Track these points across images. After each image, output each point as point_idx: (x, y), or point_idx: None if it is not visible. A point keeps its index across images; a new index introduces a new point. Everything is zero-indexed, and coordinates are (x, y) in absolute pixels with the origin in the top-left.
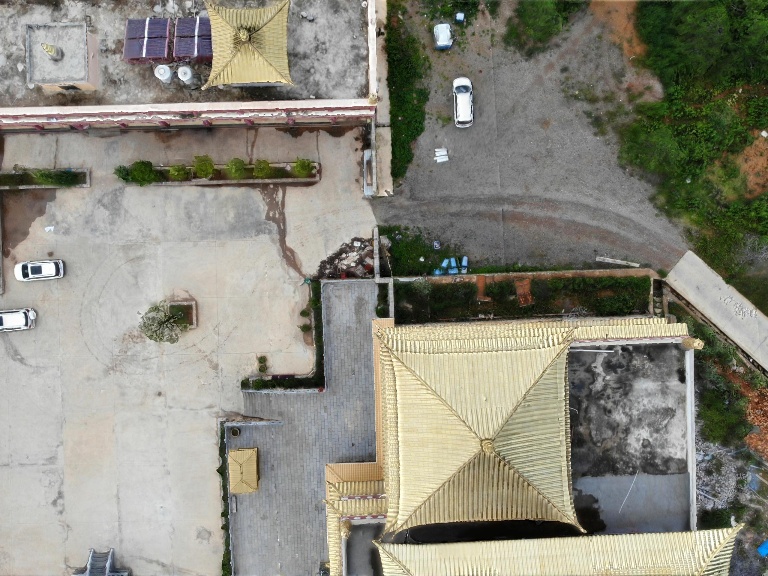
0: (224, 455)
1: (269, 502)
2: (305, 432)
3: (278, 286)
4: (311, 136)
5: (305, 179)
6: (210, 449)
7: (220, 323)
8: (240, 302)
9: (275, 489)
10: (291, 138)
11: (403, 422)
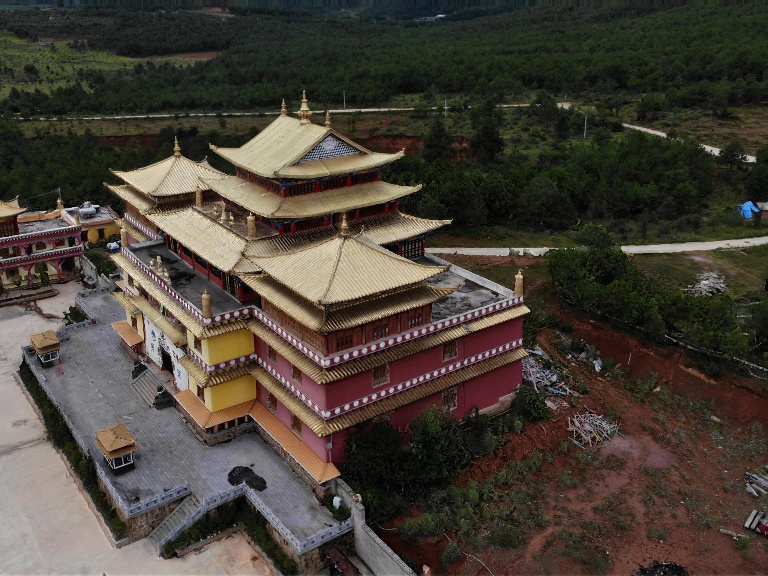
0: (26, 369)
1: (74, 370)
2: (90, 340)
3: (44, 325)
4: (46, 287)
5: (48, 293)
6: (12, 388)
7: (3, 345)
8: (16, 336)
9: (76, 364)
10: (33, 290)
11: (134, 182)
